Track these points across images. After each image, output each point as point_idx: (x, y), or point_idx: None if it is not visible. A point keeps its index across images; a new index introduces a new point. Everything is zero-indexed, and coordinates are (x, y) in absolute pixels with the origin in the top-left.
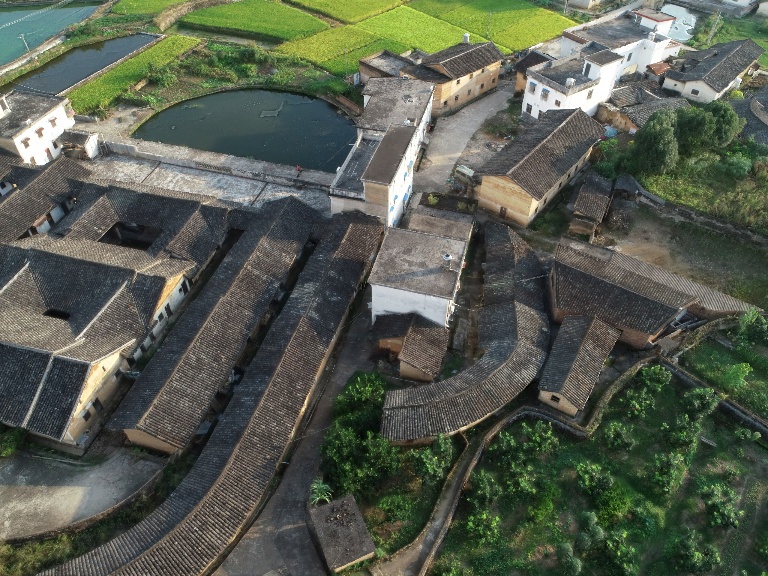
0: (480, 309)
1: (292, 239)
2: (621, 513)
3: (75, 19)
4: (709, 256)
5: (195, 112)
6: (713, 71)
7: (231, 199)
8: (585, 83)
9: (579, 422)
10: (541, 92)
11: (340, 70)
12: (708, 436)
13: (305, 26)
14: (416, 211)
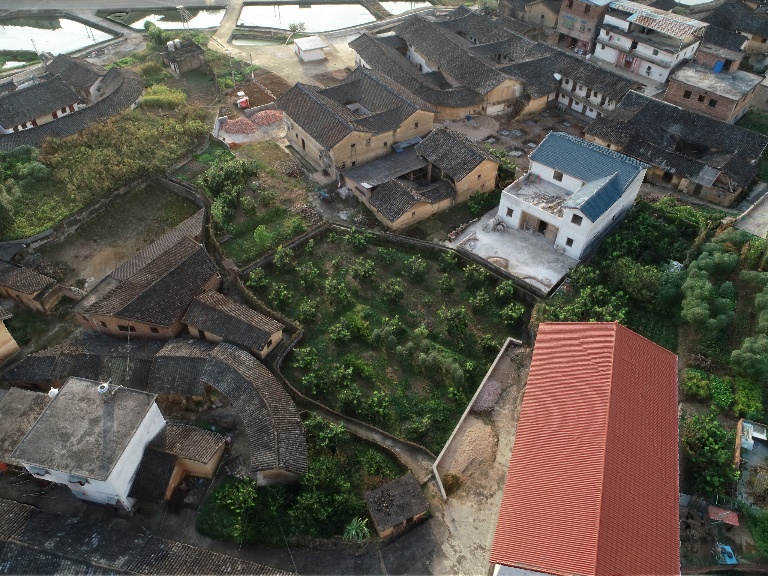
0: None
1: None
2: None
3: None
4: (126, 225)
5: None
6: None
7: None
8: None
9: (287, 336)
10: None
11: None
12: None
13: None
14: None
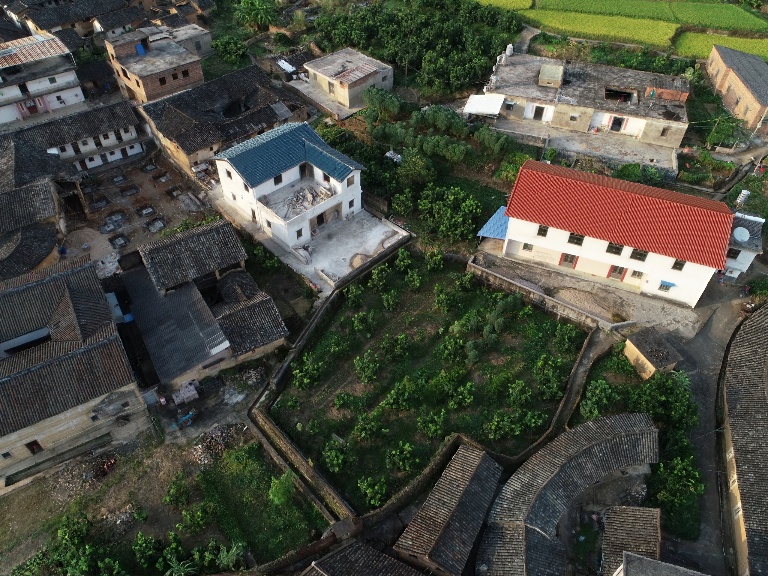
0: None
1: None
2: None
3: None
4: None
5: None
6: None
7: None
8: None
9: None
10: None
11: None
12: None
13: None
14: None
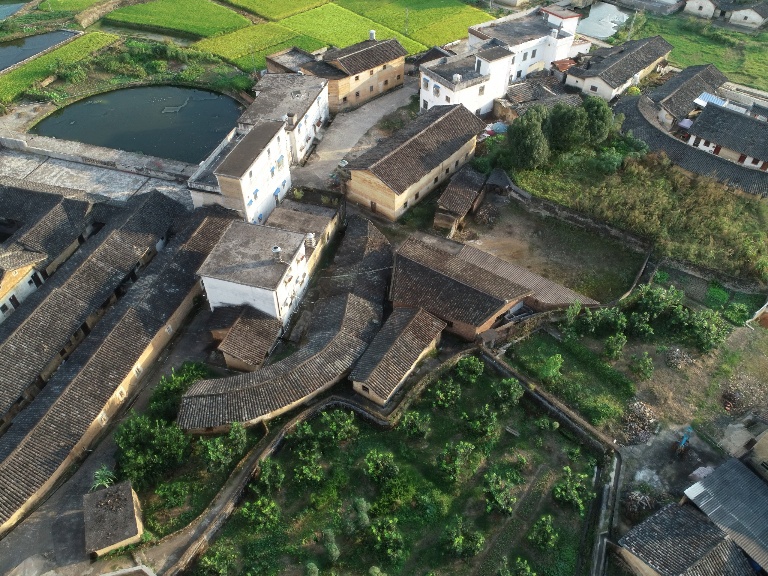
0: (318, 301)
1: (148, 232)
2: (403, 500)
3: (1, 16)
4: (567, 250)
5: (99, 108)
6: (612, 68)
7: (110, 193)
8: (473, 79)
9: (388, 412)
10: (433, 88)
11: (250, 67)
12: (514, 426)
13: (226, 23)
14: (281, 205)
